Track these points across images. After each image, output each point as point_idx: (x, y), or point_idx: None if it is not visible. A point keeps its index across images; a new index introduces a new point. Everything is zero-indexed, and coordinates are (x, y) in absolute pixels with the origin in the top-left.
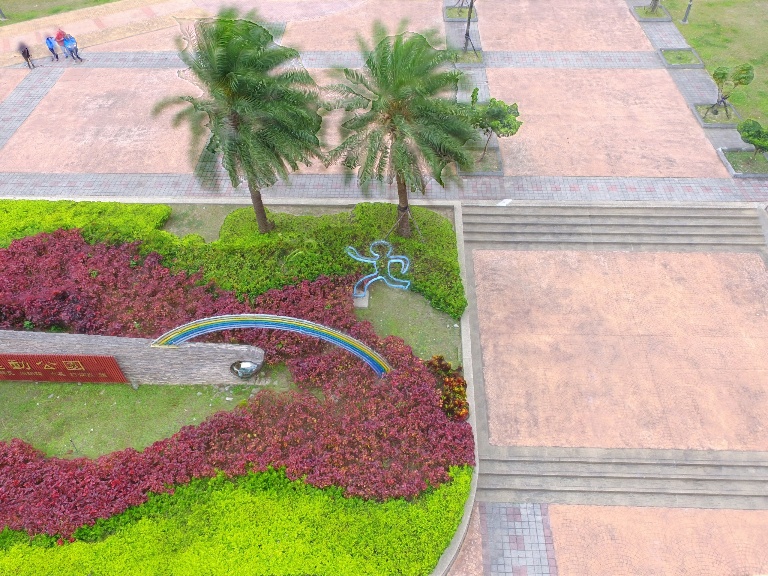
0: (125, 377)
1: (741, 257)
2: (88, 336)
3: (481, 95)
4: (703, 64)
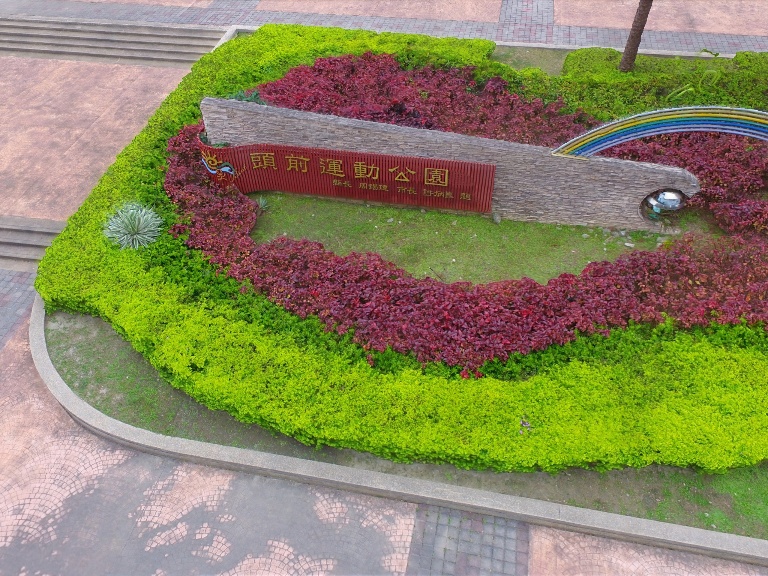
0: (490, 204)
1: None
2: (466, 136)
3: None
4: None
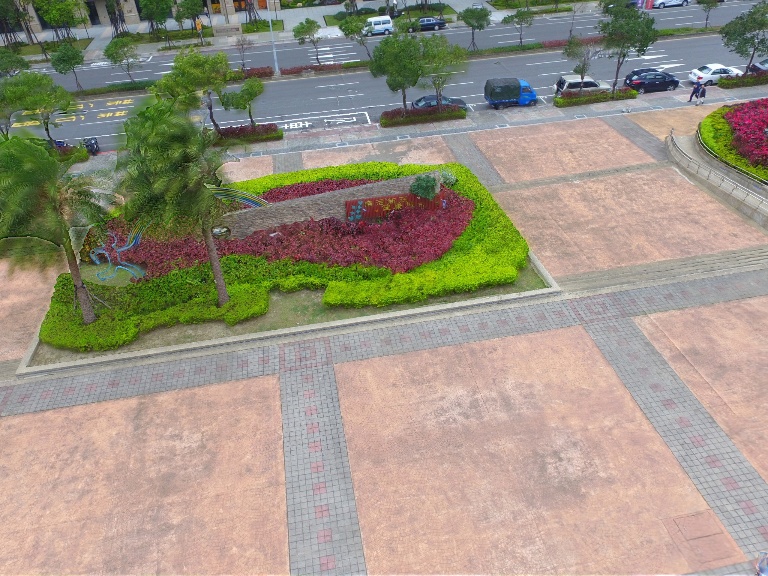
0: None
1: None
2: (312, 198)
3: None
4: None
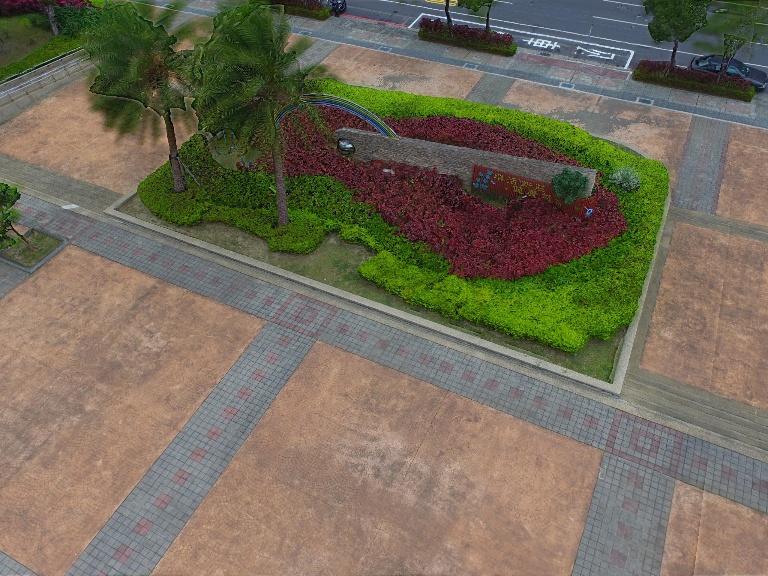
0: None
1: None
2: (441, 147)
3: None
4: None
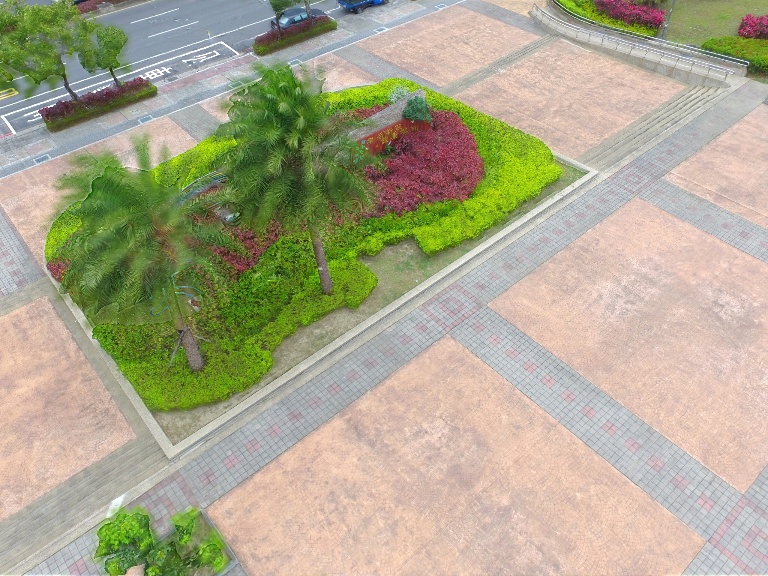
0: None
1: None
2: None
3: None
4: None
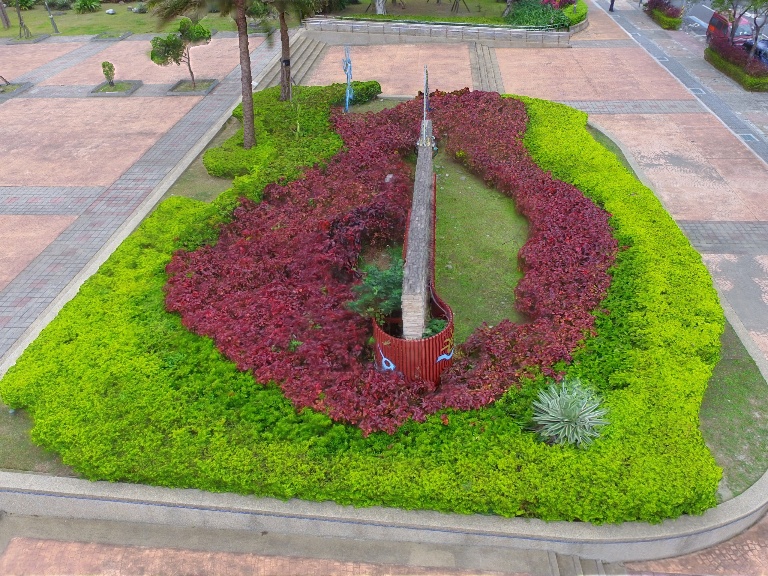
0: None
1: (334, 49)
2: (419, 169)
3: (84, 87)
4: (130, 32)
